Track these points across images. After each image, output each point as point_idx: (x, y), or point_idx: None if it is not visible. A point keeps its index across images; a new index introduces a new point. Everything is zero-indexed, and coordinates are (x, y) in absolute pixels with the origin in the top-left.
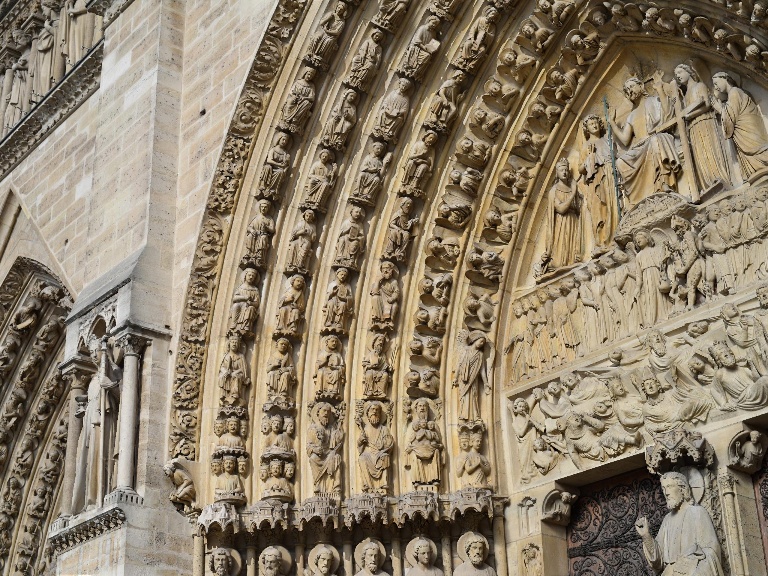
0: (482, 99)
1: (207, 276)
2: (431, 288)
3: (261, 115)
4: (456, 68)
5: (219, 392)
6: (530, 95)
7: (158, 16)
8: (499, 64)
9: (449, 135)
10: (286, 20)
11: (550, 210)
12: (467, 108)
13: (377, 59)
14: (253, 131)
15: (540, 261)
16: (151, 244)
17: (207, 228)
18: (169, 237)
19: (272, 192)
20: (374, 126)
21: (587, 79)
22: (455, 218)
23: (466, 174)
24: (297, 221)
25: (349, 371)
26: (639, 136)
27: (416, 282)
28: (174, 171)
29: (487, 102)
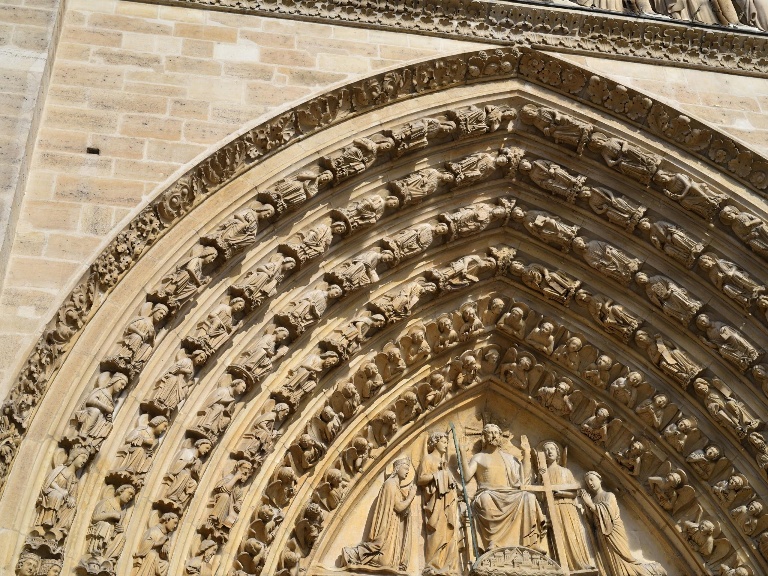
0: (375, 354)
1: (58, 348)
2: (270, 518)
3: (187, 211)
4: (372, 310)
5: (32, 513)
6: (409, 380)
7: (53, 1)
8: (404, 334)
9: (336, 368)
10: (264, 142)
11: (389, 502)
12: (358, 353)
13: (327, 249)
14: (170, 220)
15: (359, 548)
16: (0, 259)
17: (82, 290)
18: (6, 263)
19: (178, 304)
20: (285, 309)
21: (451, 398)
22: (311, 455)
23: (338, 417)
24: (174, 353)
25: (168, 569)
26: (498, 482)
27: (251, 501)
28: (24, 186)
29: (377, 360)
